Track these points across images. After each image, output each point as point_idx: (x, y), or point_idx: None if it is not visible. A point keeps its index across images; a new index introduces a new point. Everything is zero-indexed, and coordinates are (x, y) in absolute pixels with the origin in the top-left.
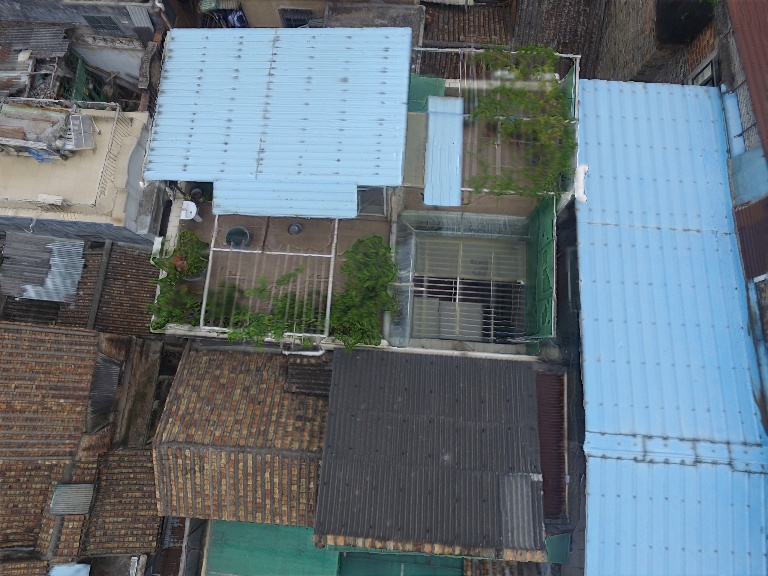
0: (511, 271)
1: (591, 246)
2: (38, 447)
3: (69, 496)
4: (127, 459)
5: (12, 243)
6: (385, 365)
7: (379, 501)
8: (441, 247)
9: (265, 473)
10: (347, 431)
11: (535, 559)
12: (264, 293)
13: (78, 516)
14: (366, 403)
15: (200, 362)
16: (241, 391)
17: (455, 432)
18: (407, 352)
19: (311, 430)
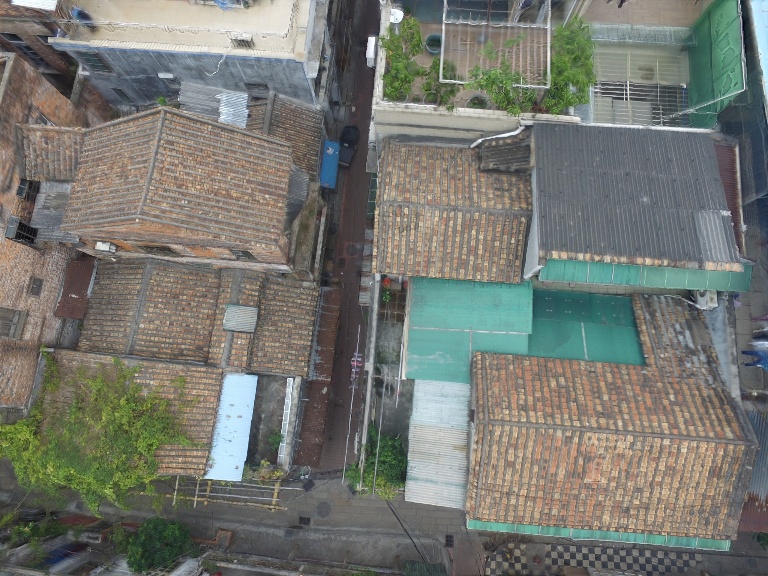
0: (675, 76)
1: (767, 28)
2: (251, 231)
3: (238, 315)
4: (281, 294)
5: (186, 92)
6: (581, 135)
7: (592, 229)
8: (611, 57)
9: (472, 230)
10: (556, 181)
11: (734, 269)
12: (492, 55)
13: (245, 334)
14: (569, 162)
15: (400, 151)
16: (441, 171)
17: (650, 182)
18: (598, 126)
19: (510, 196)
